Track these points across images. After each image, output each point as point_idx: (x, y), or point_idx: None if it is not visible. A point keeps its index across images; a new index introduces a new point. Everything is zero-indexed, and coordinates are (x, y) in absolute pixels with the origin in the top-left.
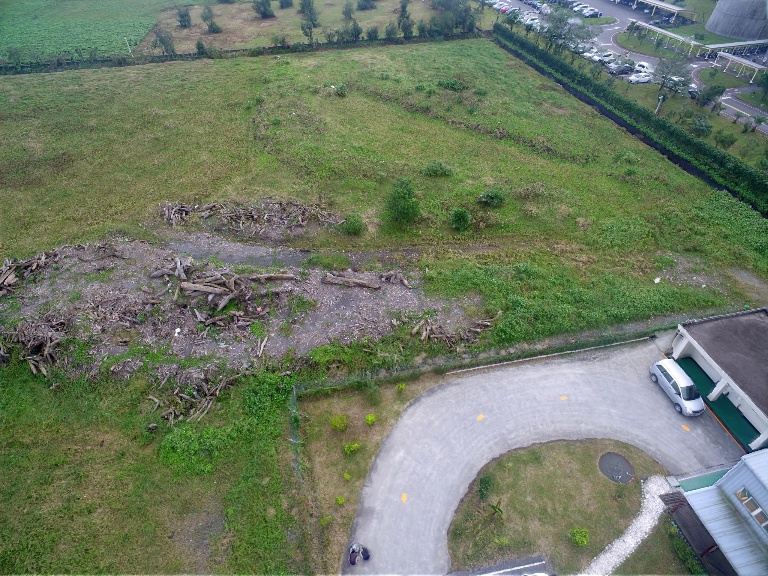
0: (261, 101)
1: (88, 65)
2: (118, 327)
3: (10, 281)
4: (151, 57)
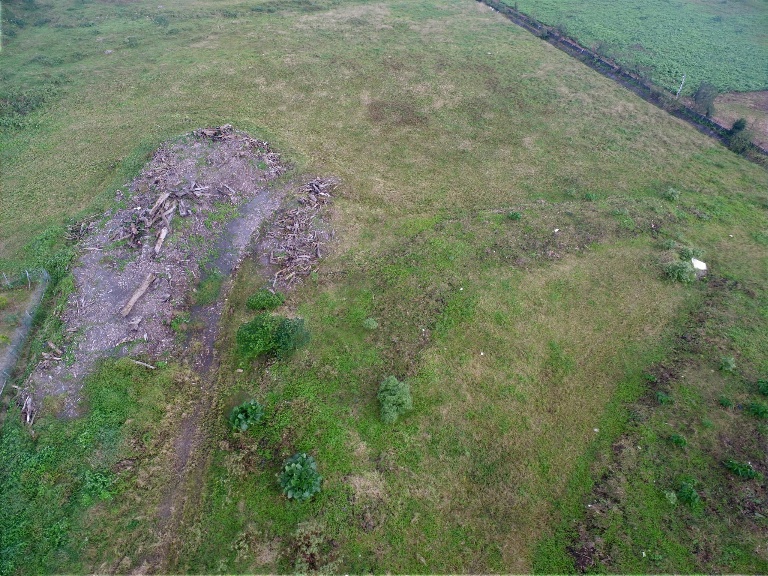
0: (588, 199)
1: (633, 84)
2: (151, 182)
3: (208, 133)
4: (681, 107)
